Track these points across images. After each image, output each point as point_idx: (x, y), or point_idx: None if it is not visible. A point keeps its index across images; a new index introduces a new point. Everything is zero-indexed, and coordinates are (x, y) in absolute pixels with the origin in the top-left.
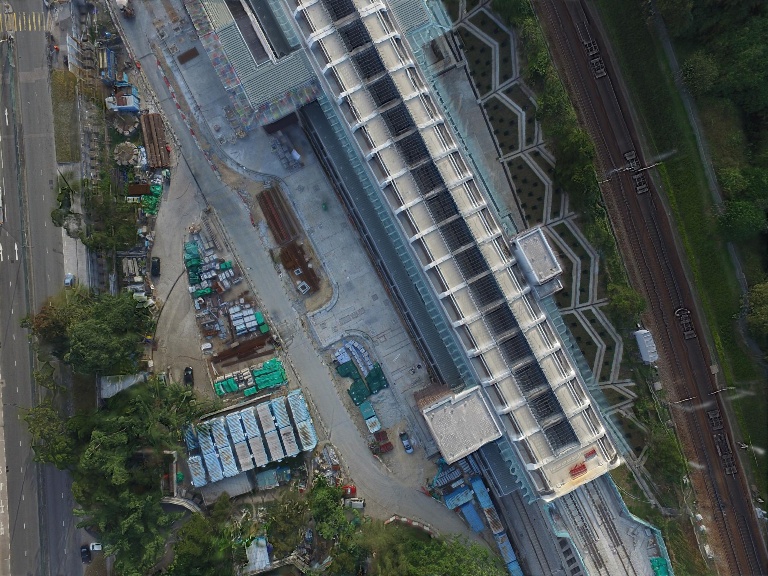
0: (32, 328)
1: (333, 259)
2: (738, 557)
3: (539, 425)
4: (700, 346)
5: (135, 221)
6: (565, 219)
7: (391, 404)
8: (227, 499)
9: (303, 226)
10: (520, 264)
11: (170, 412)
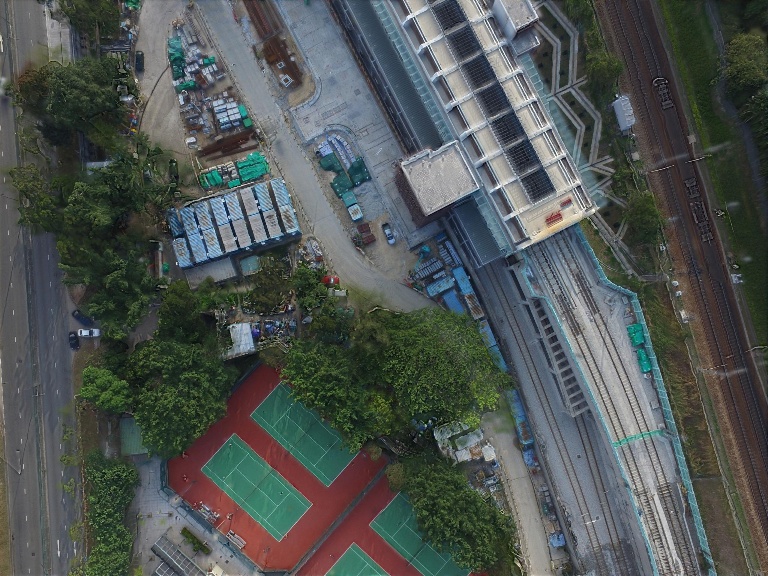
0: (16, 95)
1: (316, 54)
2: (713, 322)
3: (515, 173)
4: (678, 115)
5: (119, 14)
6: (545, 1)
7: (373, 197)
8: (211, 280)
9: (286, 21)
10: (497, 20)
11: (155, 201)
